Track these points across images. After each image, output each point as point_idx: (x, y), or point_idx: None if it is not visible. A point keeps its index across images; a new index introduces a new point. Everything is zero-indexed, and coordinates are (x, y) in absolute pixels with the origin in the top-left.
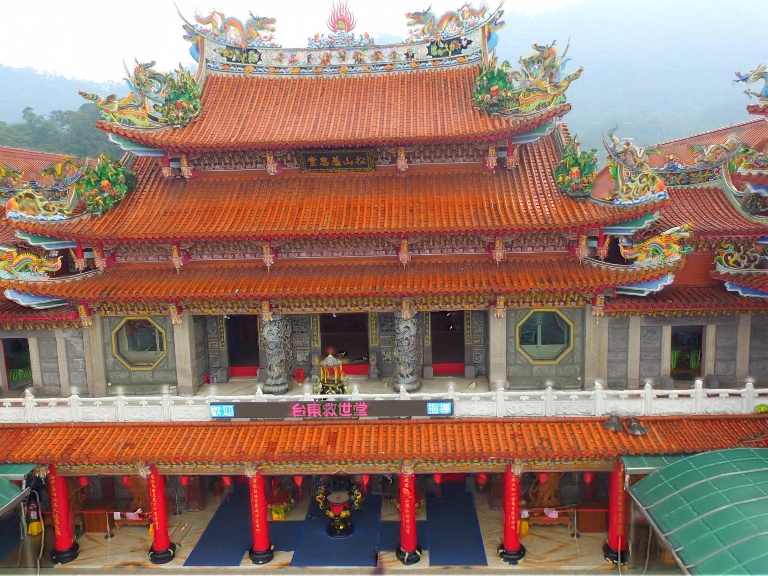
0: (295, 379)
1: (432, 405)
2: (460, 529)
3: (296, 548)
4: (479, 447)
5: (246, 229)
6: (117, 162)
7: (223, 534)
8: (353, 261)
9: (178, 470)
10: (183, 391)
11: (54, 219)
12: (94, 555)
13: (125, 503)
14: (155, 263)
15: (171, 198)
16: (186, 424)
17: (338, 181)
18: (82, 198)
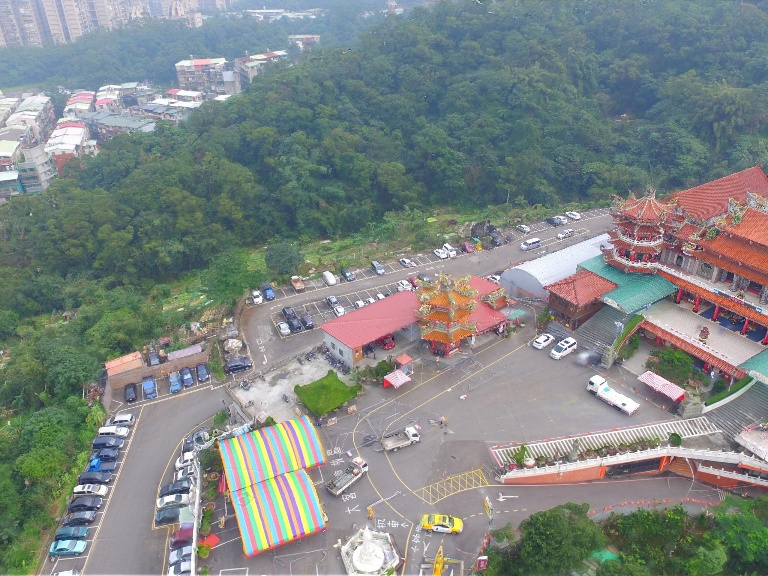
0: (740, 289)
1: (757, 309)
2: (760, 336)
3: (722, 322)
4: (760, 320)
5: (736, 258)
6: (766, 47)
7: (709, 313)
8: (761, 271)
9: (704, 298)
10: (712, 282)
11: (698, 239)
12: (683, 305)
13: (692, 298)
14: (716, 253)
15: (725, 240)
16: (708, 291)
17: (767, 251)
18: (706, 228)
